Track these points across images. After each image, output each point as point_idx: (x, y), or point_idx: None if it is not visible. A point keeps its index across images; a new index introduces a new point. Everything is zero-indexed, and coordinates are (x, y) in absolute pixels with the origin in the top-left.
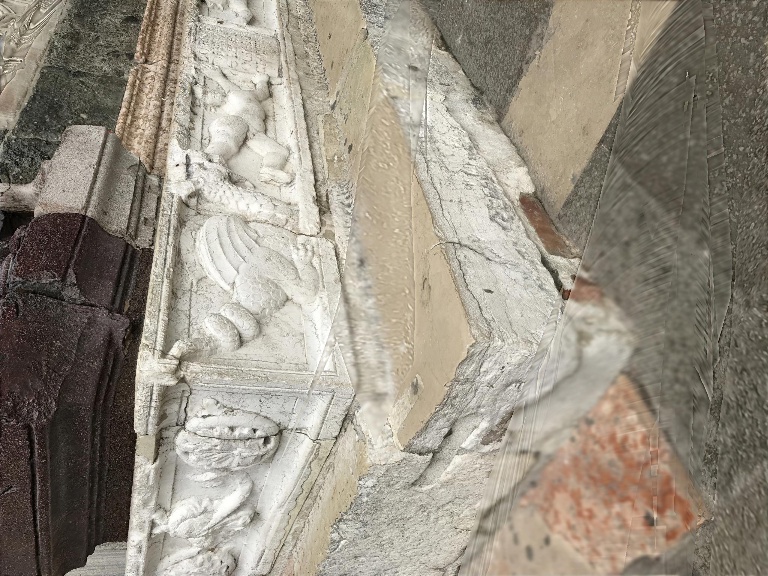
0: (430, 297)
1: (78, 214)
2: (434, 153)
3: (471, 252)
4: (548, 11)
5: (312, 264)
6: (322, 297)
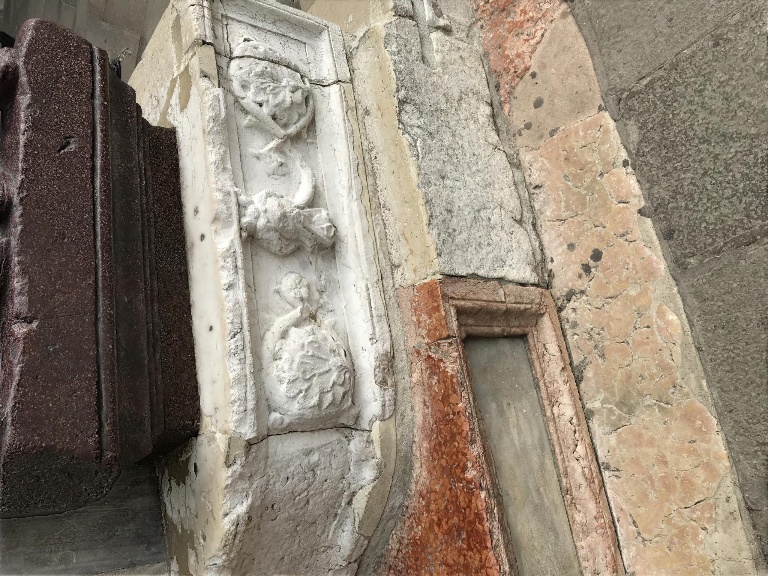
0: None
1: None
2: None
3: None
4: None
5: None
6: None
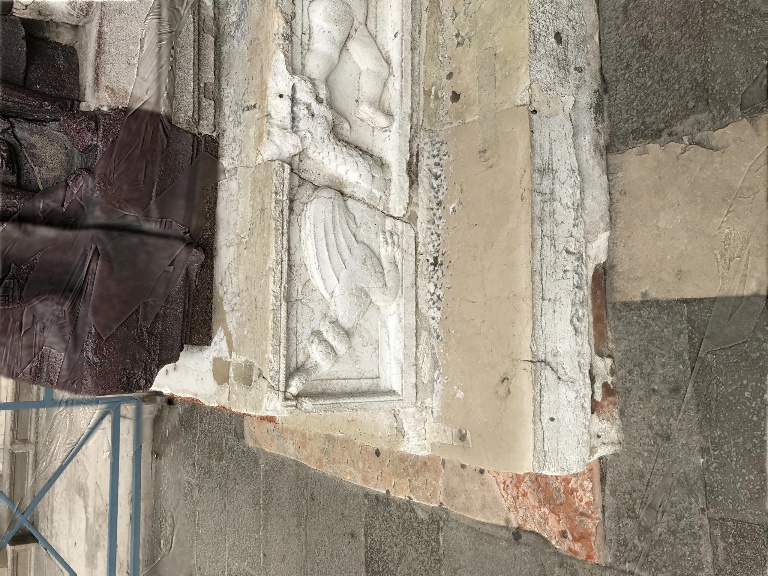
0: (507, 400)
1: None
2: (550, 221)
3: (550, 371)
4: (723, 117)
5: (395, 259)
6: (399, 305)
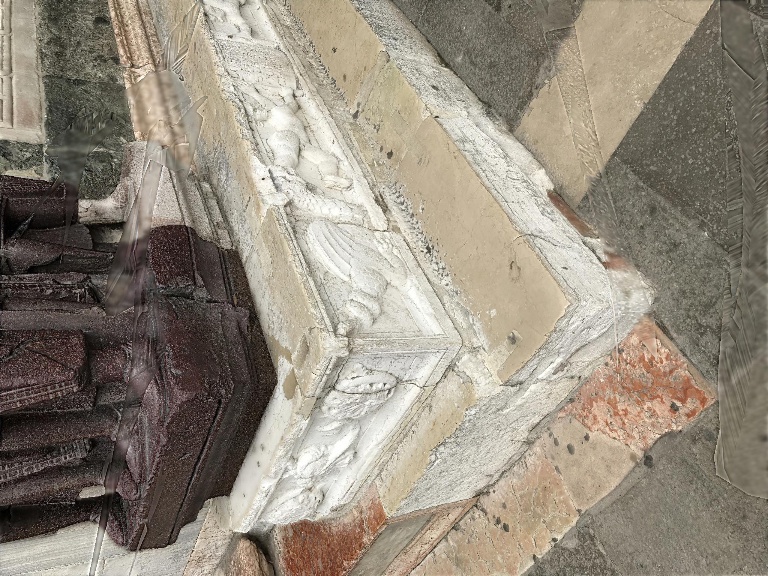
0: (521, 275)
1: (181, 225)
2: (485, 164)
3: (542, 241)
4: None
5: (394, 254)
6: (412, 280)
